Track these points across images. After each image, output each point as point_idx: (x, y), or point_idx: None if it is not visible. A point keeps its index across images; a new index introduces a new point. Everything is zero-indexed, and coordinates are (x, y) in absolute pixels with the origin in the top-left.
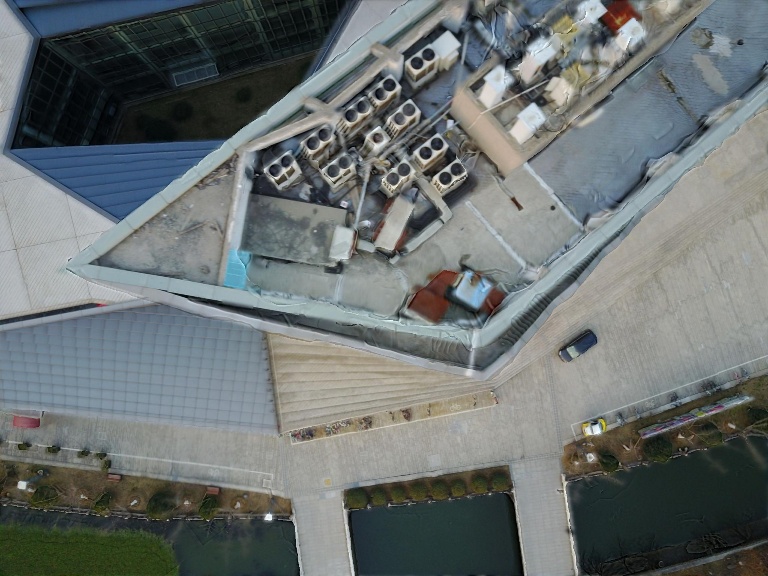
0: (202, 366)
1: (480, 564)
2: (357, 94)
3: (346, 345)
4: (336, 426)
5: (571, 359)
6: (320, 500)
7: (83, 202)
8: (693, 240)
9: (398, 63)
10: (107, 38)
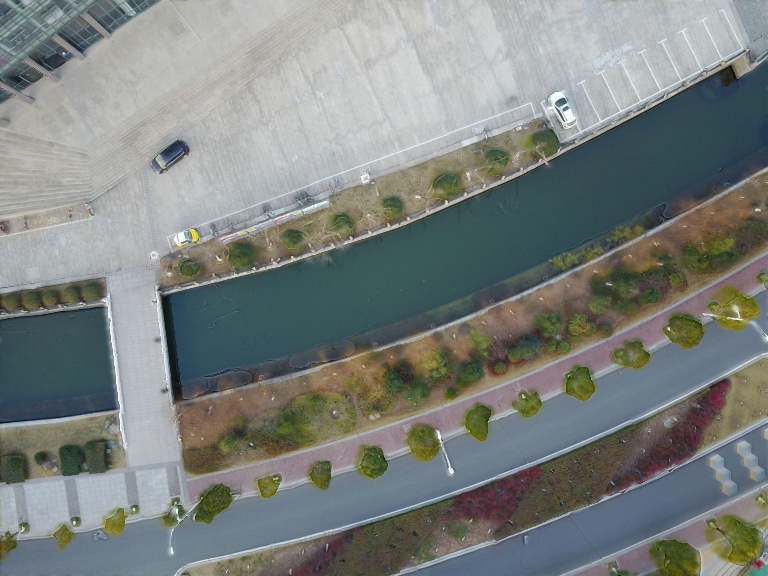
0: None
1: (93, 381)
2: None
3: None
4: None
5: (161, 169)
6: None
7: None
8: (285, 50)
9: None
10: None
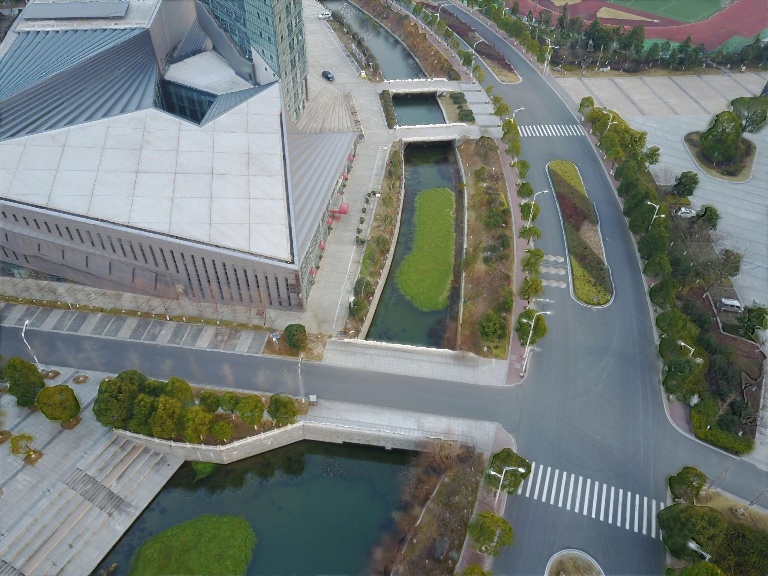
0: None
1: None
2: None
3: None
4: None
5: (333, 77)
6: None
7: (232, 109)
8: None
9: None
10: None
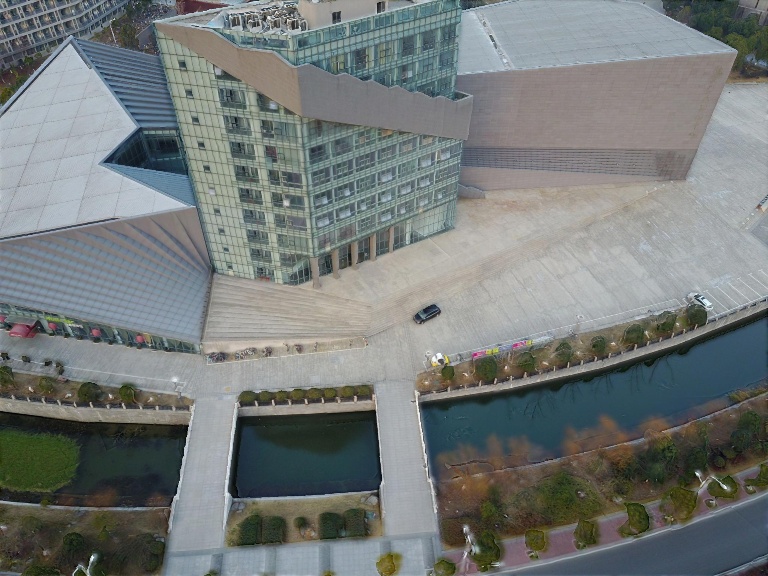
0: (161, 295)
1: (346, 471)
2: (266, 8)
3: (245, 51)
4: (244, 353)
5: (422, 319)
6: (218, 401)
7: (131, 179)
8: (503, 267)
9: (281, 4)
10: (171, 140)
